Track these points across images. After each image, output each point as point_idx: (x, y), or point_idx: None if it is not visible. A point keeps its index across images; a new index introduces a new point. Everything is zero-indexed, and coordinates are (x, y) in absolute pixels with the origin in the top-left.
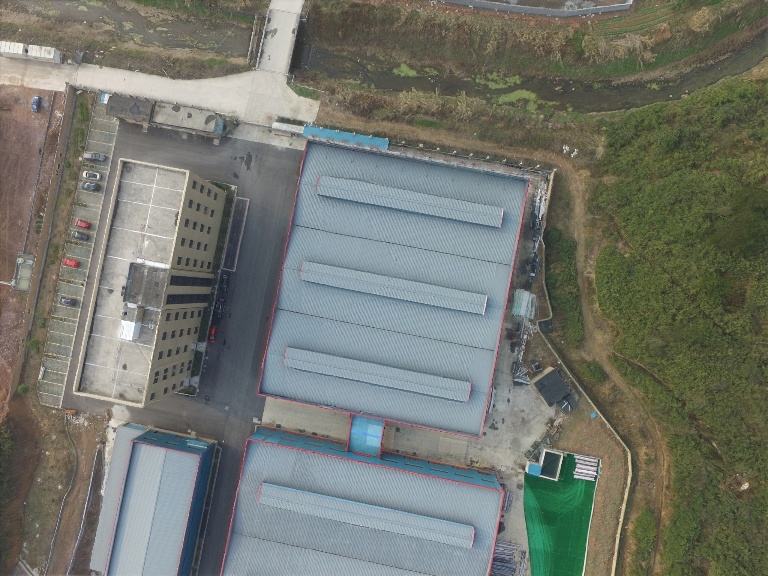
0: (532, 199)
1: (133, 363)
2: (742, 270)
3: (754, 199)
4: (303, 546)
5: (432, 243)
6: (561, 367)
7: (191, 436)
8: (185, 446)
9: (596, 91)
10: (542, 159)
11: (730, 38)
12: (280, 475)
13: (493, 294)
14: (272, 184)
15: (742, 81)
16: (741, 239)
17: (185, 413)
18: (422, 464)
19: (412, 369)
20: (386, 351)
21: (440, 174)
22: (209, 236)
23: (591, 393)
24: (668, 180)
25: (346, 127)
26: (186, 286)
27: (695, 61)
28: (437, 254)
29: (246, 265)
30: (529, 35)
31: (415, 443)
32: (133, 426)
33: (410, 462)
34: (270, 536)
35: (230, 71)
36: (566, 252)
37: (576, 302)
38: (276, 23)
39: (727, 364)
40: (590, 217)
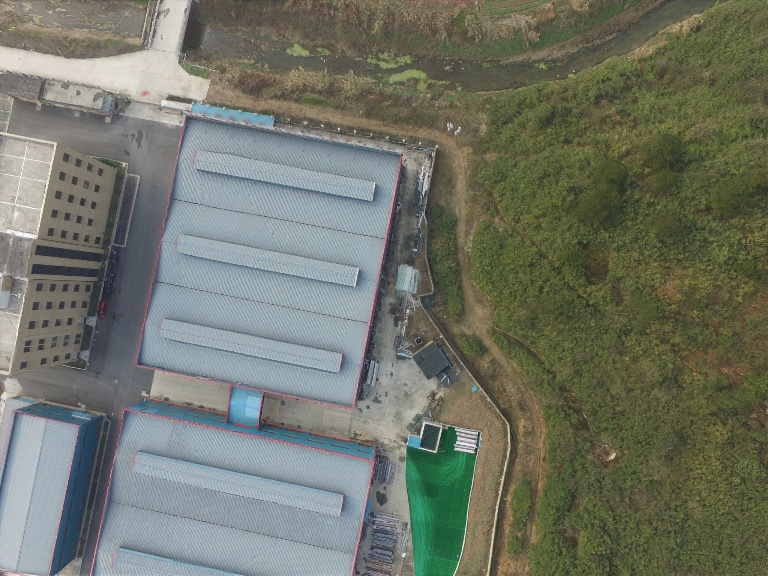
0: (416, 176)
1: (2, 332)
2: (602, 242)
3: (608, 171)
4: (179, 515)
5: (308, 217)
6: (443, 341)
7: (80, 409)
8: (69, 417)
9: (485, 71)
10: (427, 137)
11: (616, 18)
12: (156, 445)
13: (367, 267)
14: (162, 161)
15: (626, 60)
16: (595, 210)
17: (75, 386)
18: (301, 435)
19: (286, 340)
20: (262, 323)
21: (317, 149)
22: (95, 211)
23: (473, 367)
24: (540, 155)
25: (235, 105)
26: (61, 258)
27: (582, 41)
28: (313, 228)
29: (136, 241)
30: (414, 14)
31: (300, 416)
32: (23, 399)
33: (289, 433)
34: (147, 505)
35: (123, 50)
36: (446, 227)
37: (455, 276)
38: (168, 3)
39: (591, 335)
40: (471, 193)
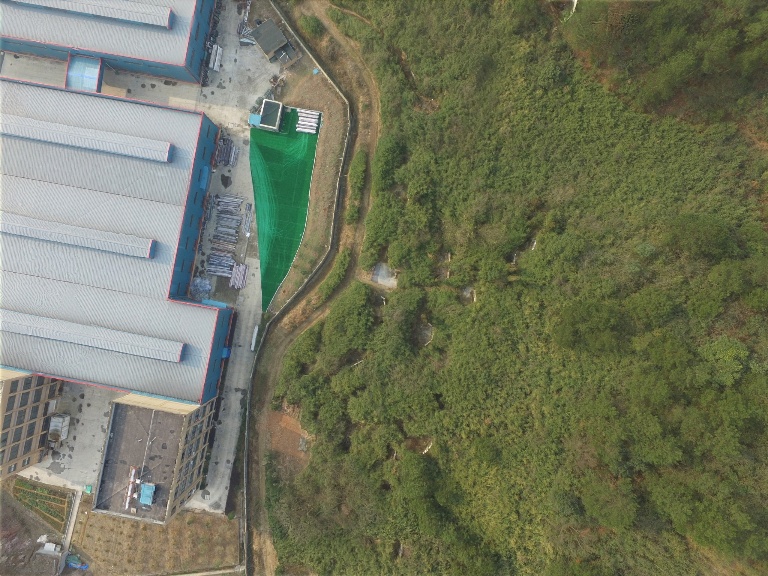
0: None
1: None
2: None
3: None
4: (13, 174)
5: None
6: (285, 27)
7: None
8: None
9: None
10: None
11: None
12: None
13: None
14: None
15: None
16: None
17: None
18: None
19: None
20: None
21: None
22: None
23: (315, 53)
24: None
25: None
26: None
27: None
28: None
29: None
30: None
31: None
32: None
33: None
34: None
35: None
36: None
37: None
38: None
39: None
40: None
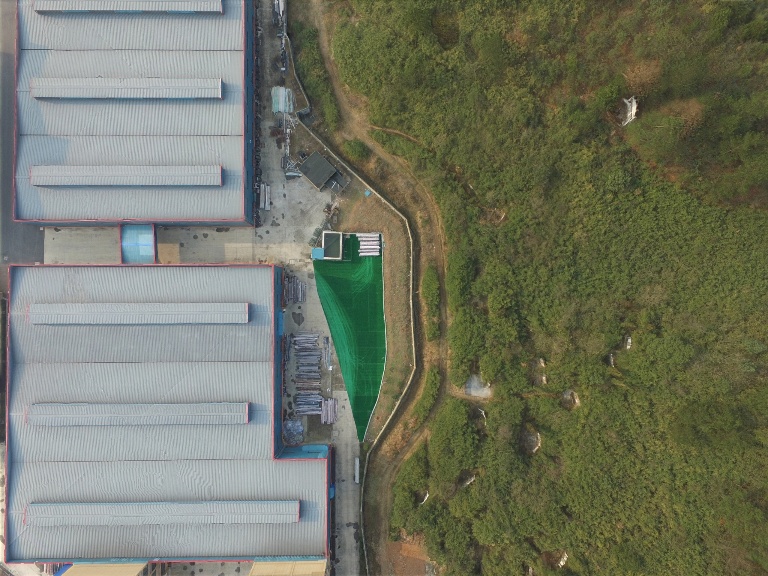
0: None
1: None
2: (447, 3)
3: None
4: (88, 361)
5: (163, 42)
6: (329, 154)
7: None
8: None
9: None
10: None
11: None
12: (51, 295)
13: (231, 80)
14: (10, 28)
15: None
16: None
17: None
18: None
19: (163, 165)
20: (137, 155)
21: None
22: None
23: (363, 174)
24: None
25: None
26: None
27: None
28: (171, 53)
29: None
30: None
31: (201, 255)
32: None
33: None
34: (53, 358)
35: None
36: (307, 38)
37: (325, 84)
38: None
39: (456, 99)
40: (327, 4)
